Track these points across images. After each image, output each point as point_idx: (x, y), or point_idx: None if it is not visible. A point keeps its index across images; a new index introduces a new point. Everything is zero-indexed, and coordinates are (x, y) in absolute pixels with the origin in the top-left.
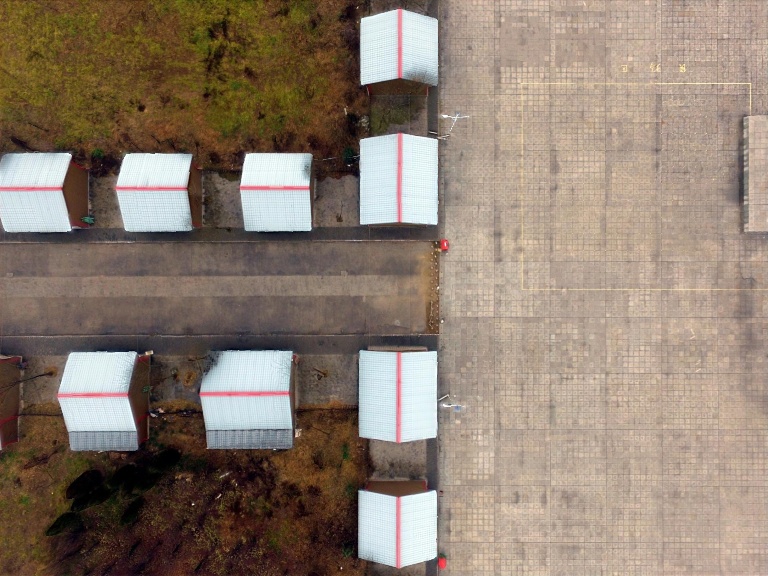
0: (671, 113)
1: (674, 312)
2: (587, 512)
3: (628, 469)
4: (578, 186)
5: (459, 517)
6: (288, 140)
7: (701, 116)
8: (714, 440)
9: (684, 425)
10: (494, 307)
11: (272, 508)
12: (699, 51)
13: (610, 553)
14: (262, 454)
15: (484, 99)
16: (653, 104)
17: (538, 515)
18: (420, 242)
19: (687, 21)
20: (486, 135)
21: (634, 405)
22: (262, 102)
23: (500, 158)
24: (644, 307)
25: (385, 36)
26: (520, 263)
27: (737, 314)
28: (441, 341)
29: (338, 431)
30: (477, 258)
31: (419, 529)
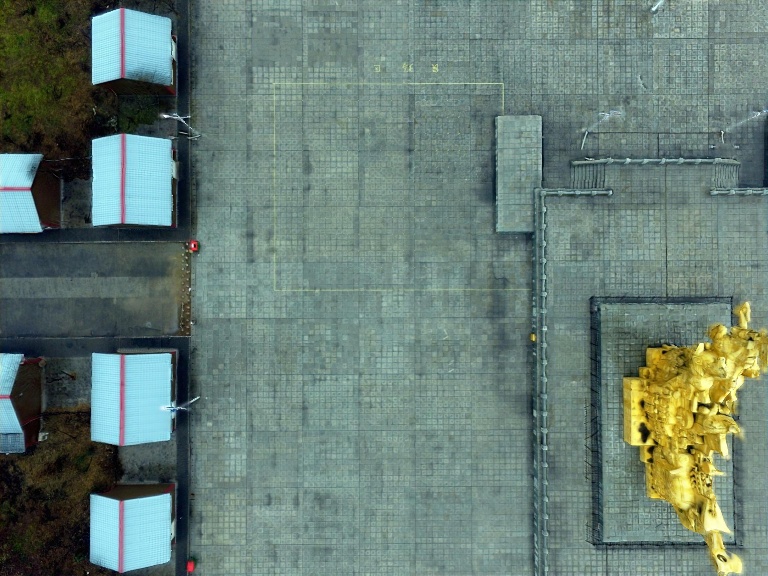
0: (424, 113)
1: (427, 312)
2: (339, 514)
3: (381, 470)
4: (331, 186)
5: (210, 520)
6: (35, 140)
7: (454, 116)
8: (467, 440)
9: (437, 425)
10: (246, 308)
11: (17, 513)
12: (452, 51)
13: (362, 554)
14: (8, 458)
15: (236, 99)
16: (406, 104)
17: (290, 517)
18: (171, 243)
19: (439, 21)
20: (238, 135)
21: (387, 406)
22: (8, 102)
23: (252, 158)
24: (397, 308)
25: (111, 35)
26: (273, 264)
27: (490, 314)
28: (193, 343)
29: (85, 434)
30: (229, 259)
31: (148, 533)
